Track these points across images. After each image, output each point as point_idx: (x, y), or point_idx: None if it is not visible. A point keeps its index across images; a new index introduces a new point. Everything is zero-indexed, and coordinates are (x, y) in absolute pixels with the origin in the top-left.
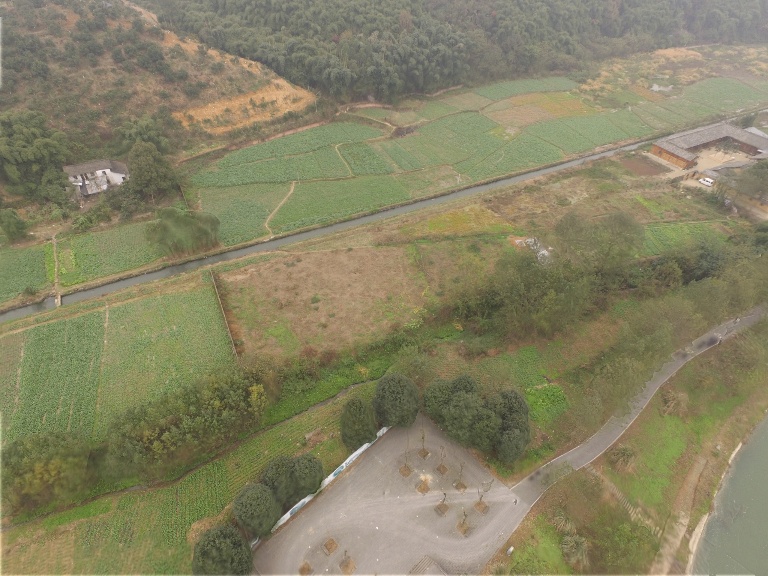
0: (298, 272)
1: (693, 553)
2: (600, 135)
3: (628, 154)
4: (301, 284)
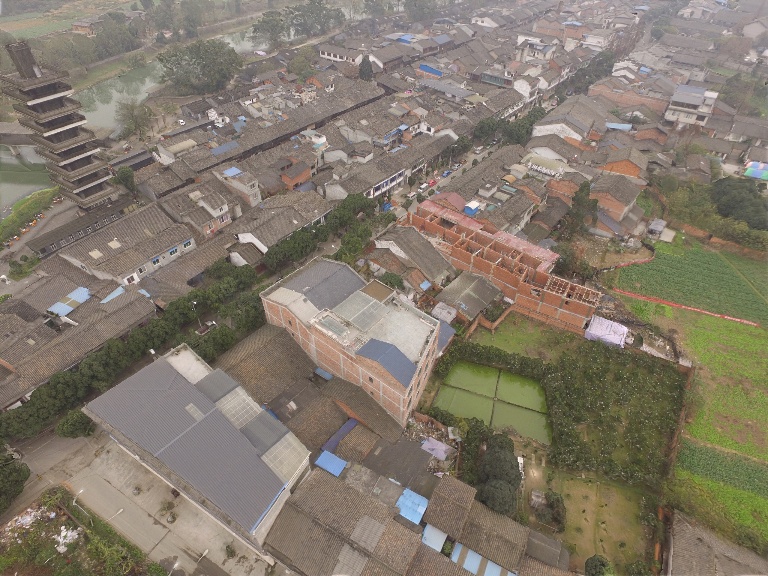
0: None
1: None
2: (47, 30)
3: (60, 33)
4: None
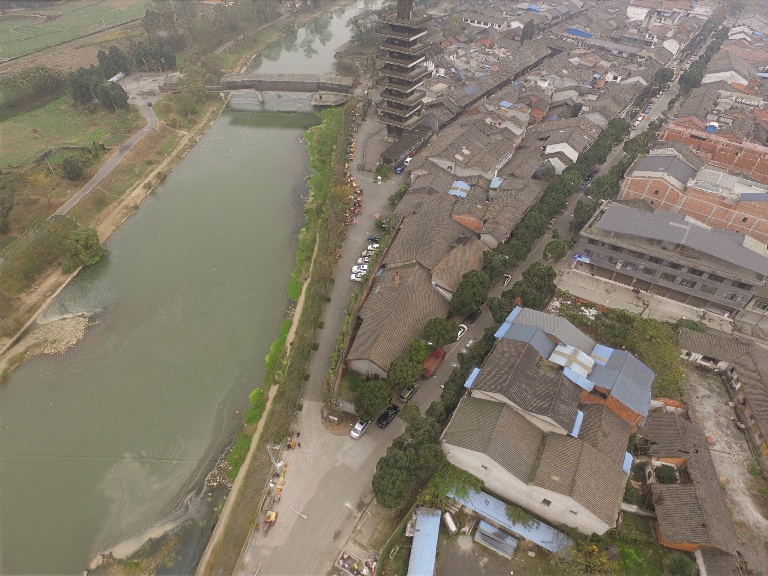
0: (39, 62)
1: None
2: None
3: None
4: (45, 64)
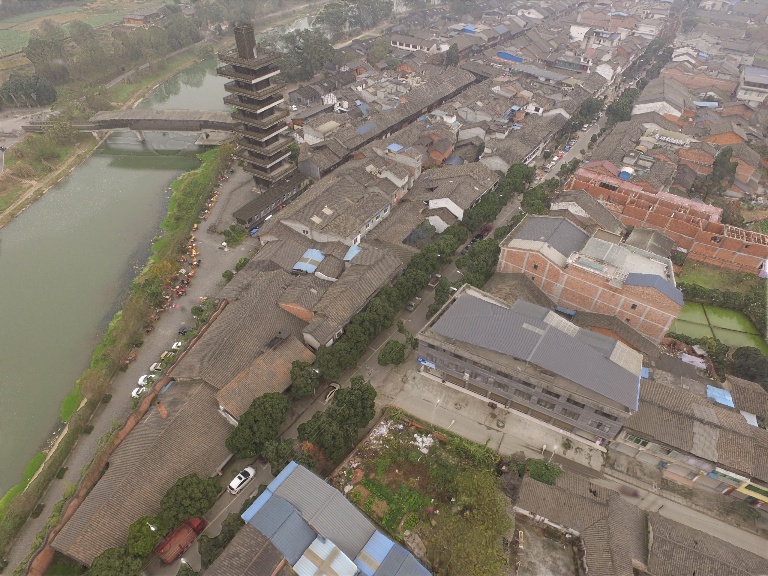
0: None
1: (136, 105)
2: (97, 24)
3: (113, 26)
4: None
